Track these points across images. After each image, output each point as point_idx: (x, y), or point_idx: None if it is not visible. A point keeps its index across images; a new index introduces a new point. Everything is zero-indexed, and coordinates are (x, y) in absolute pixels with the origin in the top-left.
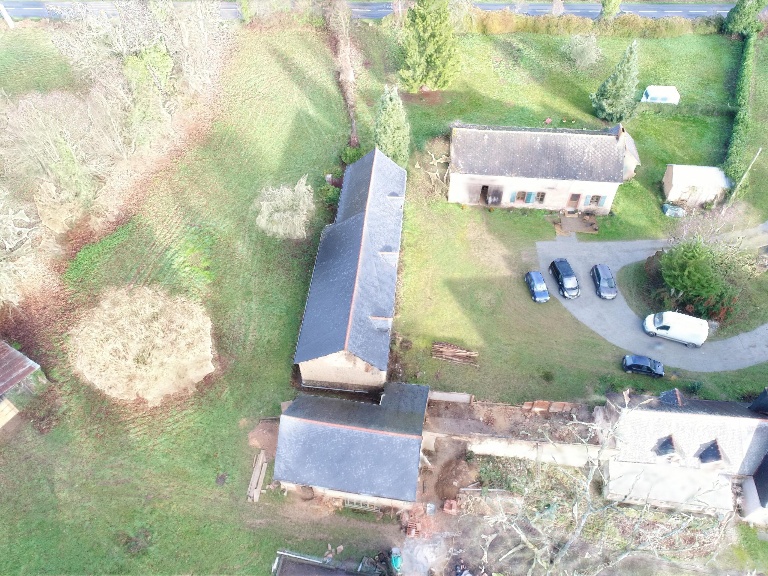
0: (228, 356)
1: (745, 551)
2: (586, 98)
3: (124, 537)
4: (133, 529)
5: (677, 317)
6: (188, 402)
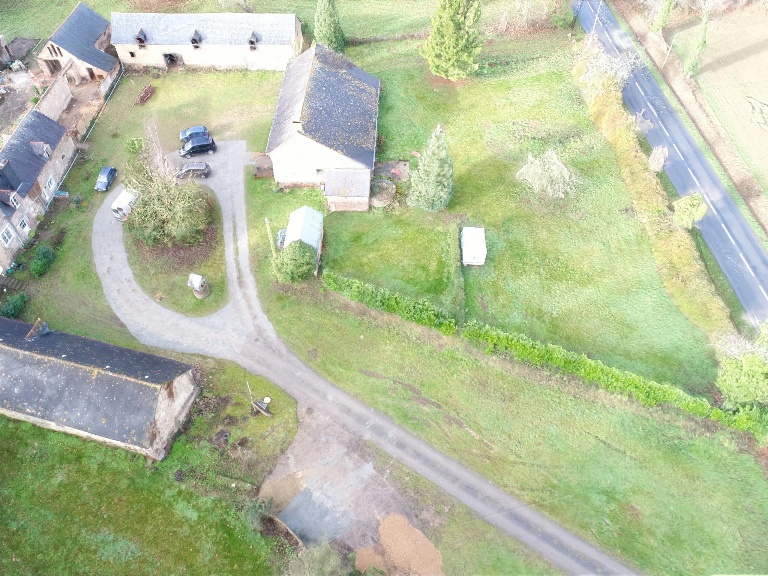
0: None
1: None
2: (470, 189)
3: (68, 0)
4: (70, 1)
5: None
6: (132, 5)
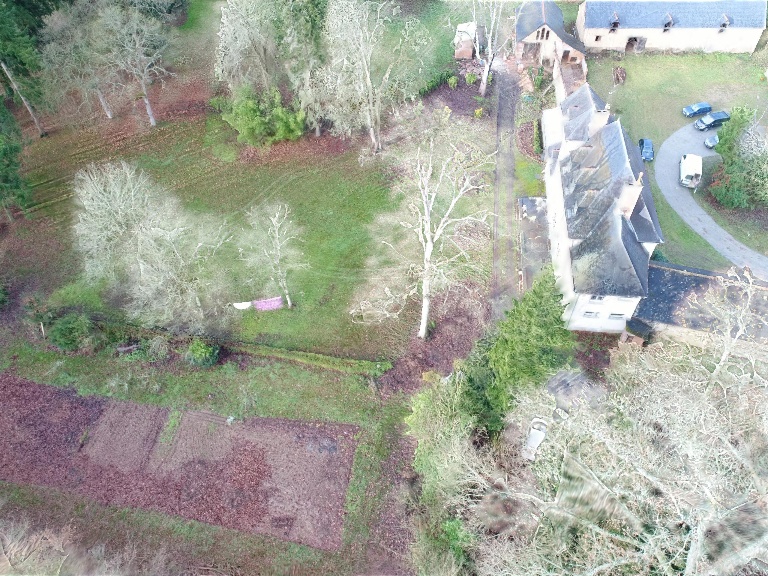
0: (580, 3)
1: (527, 167)
2: None
3: None
4: None
5: (696, 158)
6: None
